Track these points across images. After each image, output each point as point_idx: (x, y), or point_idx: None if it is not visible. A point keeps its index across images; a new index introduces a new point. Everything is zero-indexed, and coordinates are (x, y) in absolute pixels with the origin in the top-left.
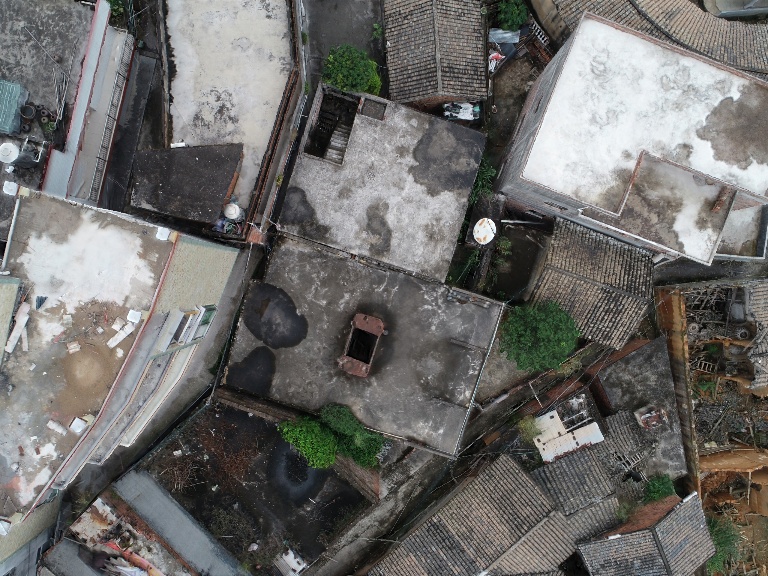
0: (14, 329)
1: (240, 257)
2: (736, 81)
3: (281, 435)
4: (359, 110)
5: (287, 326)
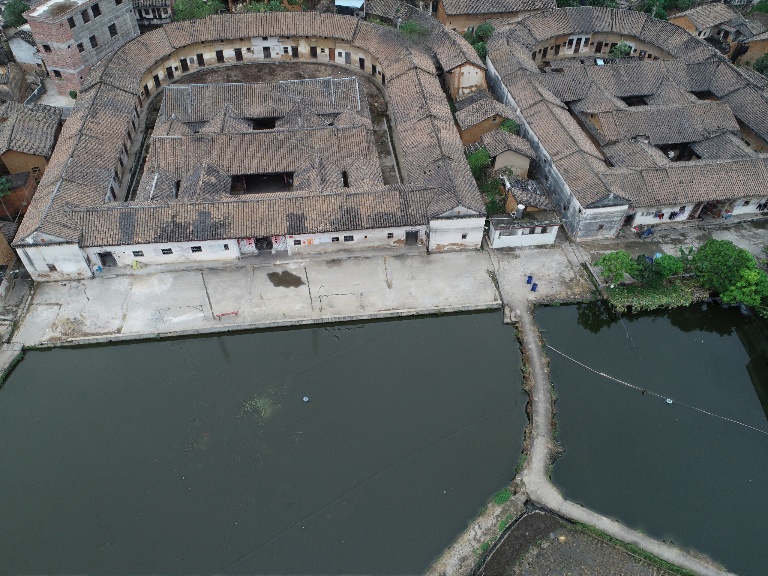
0: None
1: None
2: None
3: None
4: None
5: None
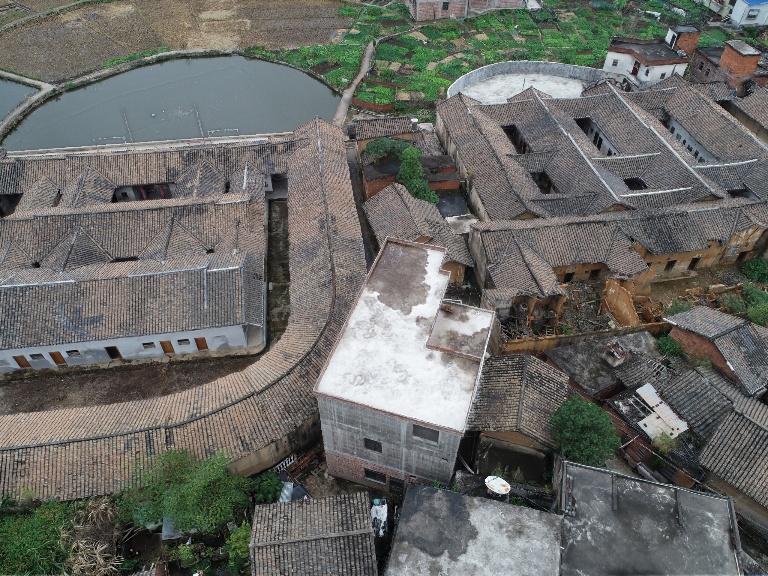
0: None
1: None
2: (365, 294)
3: None
4: None
5: None
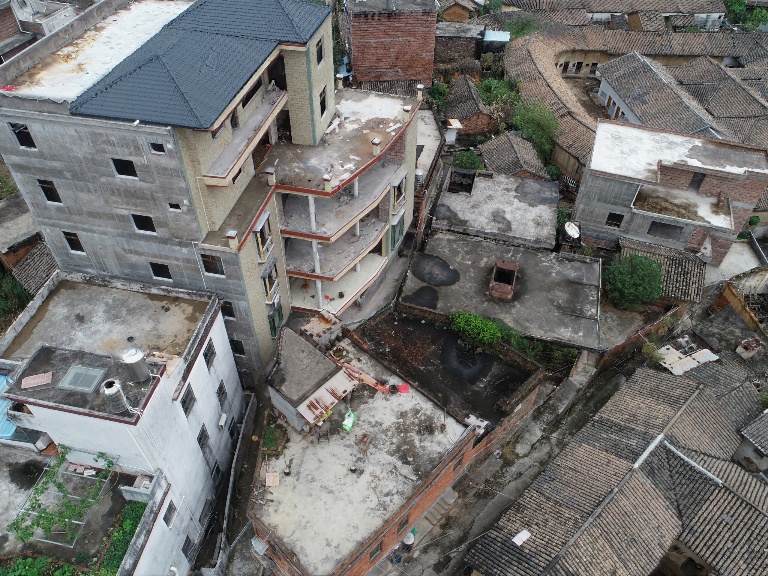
0: (331, 126)
1: (399, 260)
2: (696, 140)
3: (452, 327)
4: (477, 175)
5: (444, 275)
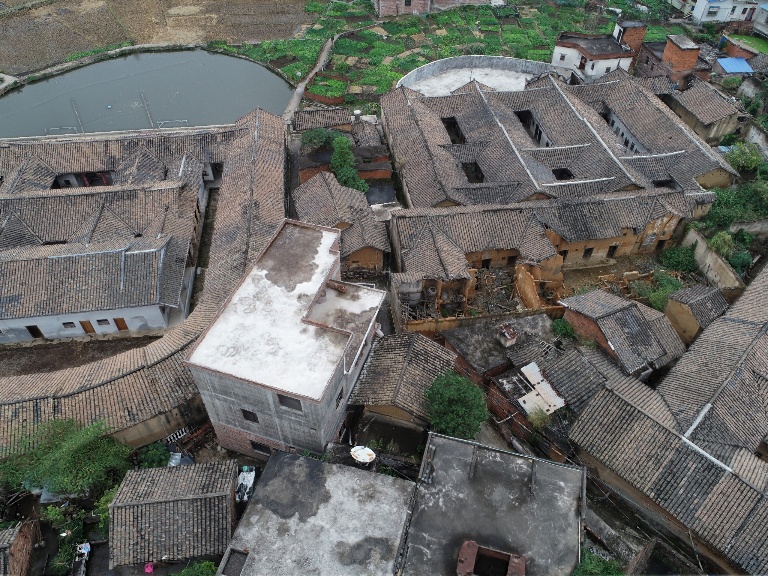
0: None
1: None
2: (254, 273)
3: None
4: None
5: None
